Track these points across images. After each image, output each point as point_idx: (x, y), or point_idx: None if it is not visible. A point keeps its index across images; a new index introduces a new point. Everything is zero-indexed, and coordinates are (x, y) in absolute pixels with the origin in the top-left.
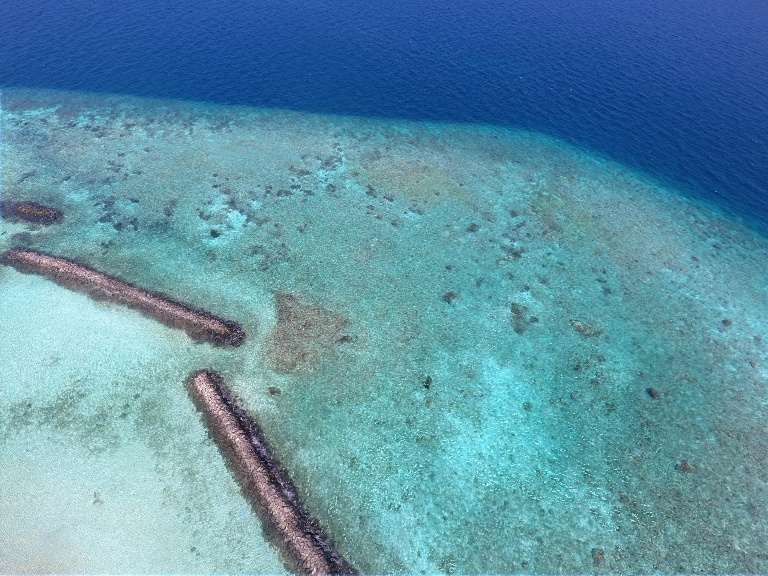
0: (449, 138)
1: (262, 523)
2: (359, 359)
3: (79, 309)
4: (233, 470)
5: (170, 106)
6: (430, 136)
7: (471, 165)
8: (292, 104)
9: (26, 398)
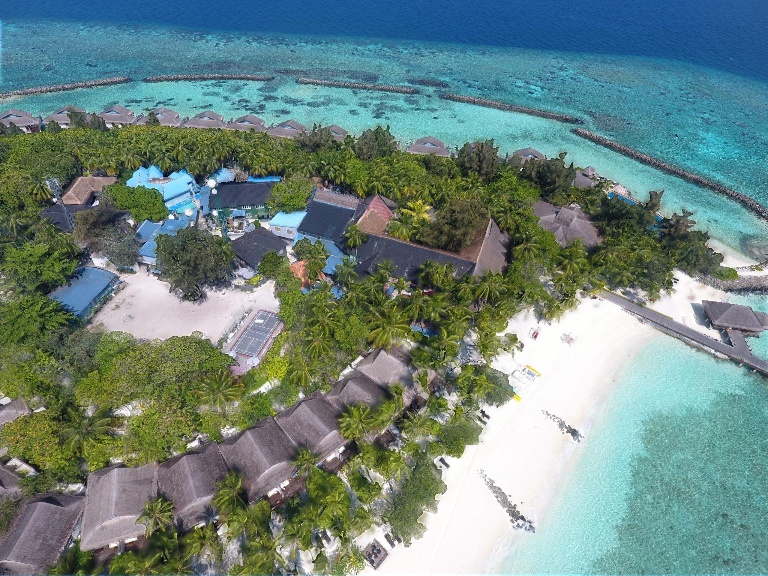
0: (621, 60)
1: (638, 161)
2: (640, 129)
3: (498, 112)
4: (615, 151)
5: (443, 45)
6: (609, 60)
7: (644, 71)
8: (519, 43)
9: (509, 133)
